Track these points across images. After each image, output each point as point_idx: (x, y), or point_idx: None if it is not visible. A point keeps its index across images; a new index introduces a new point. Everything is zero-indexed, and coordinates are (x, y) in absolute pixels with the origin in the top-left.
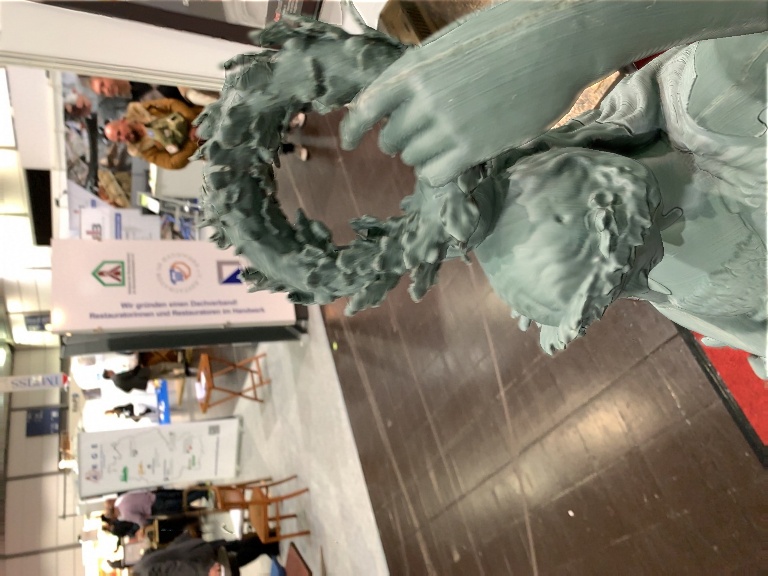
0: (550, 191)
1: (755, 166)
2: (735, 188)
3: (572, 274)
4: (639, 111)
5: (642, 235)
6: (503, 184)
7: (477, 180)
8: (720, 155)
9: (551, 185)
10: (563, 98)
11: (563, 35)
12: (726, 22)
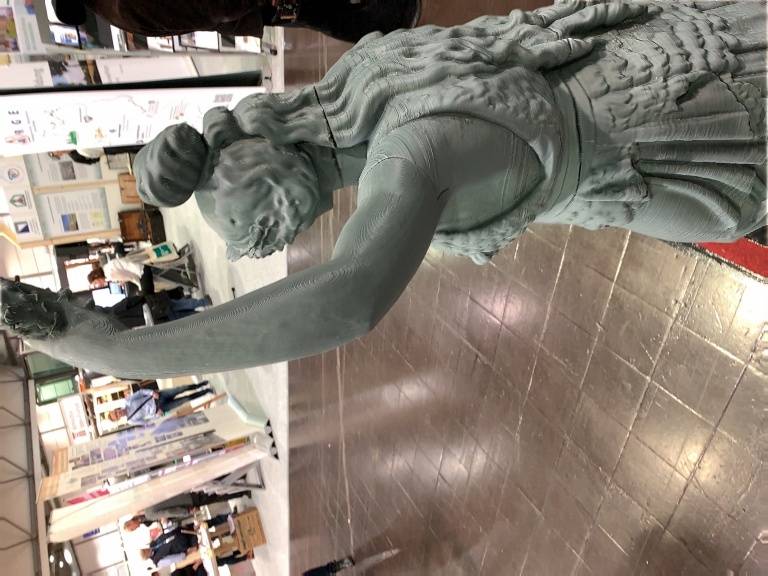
0: (235, 200)
1: None
2: None
3: None
4: (349, 135)
5: None
6: (209, 170)
7: None
8: None
9: (238, 195)
10: None
11: None
12: None
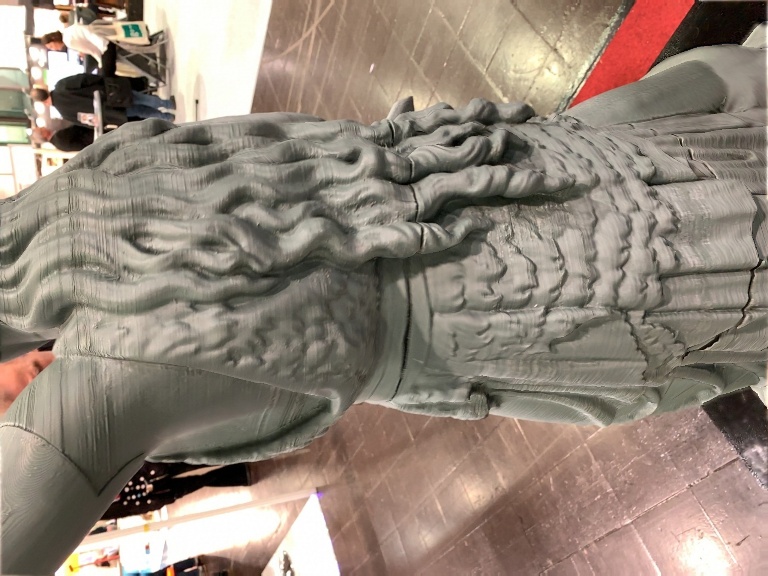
0: None
1: None
2: None
3: None
4: (20, 325)
5: None
6: None
7: None
8: None
9: None
10: None
11: None
12: None
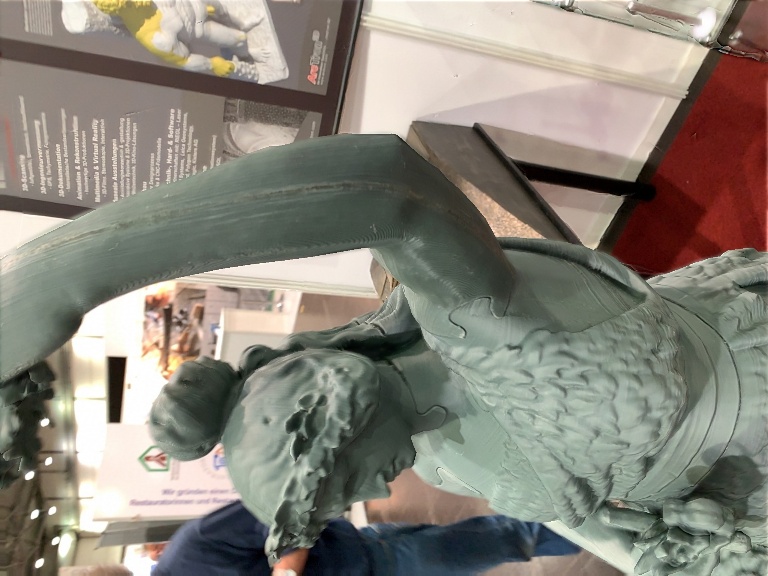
0: (268, 392)
1: (476, 365)
2: (474, 386)
3: (272, 477)
4: (393, 313)
5: (341, 437)
6: (240, 385)
7: (21, 394)
8: (450, 354)
9: (272, 386)
10: (49, 325)
11: (32, 275)
12: (212, 255)
